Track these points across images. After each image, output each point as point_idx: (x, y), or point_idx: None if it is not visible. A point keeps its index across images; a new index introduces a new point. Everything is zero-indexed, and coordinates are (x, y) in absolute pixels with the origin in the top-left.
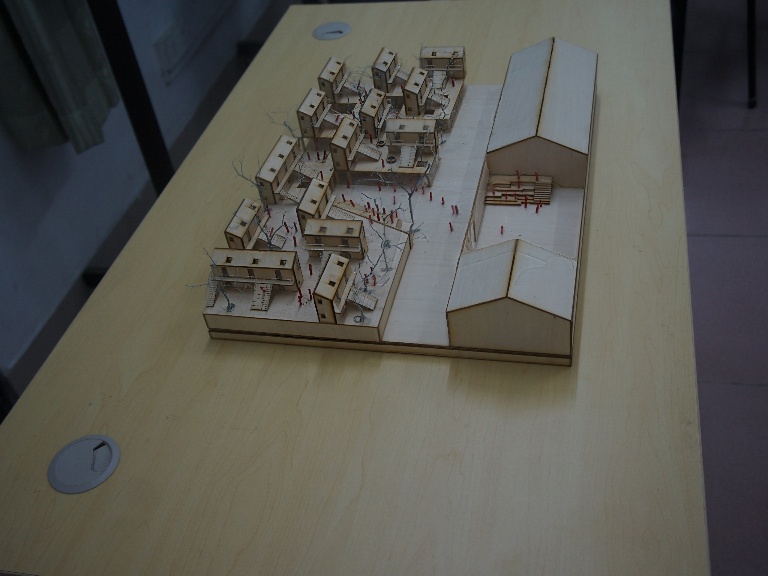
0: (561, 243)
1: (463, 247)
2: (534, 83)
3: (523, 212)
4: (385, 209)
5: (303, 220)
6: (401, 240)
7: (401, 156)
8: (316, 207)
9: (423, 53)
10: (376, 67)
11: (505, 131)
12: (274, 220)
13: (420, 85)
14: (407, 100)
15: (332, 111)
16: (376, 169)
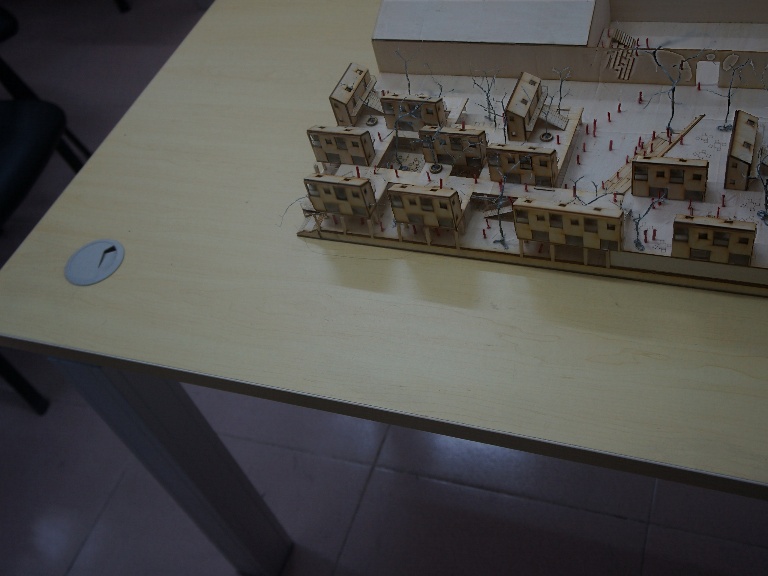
0: (704, 33)
1: (767, 52)
2: (477, 4)
3: (646, 57)
4: (621, 157)
5: (706, 178)
6: (718, 118)
7: (552, 122)
8: (692, 159)
9: (341, 98)
10: (361, 134)
11: (558, 28)
12: (662, 234)
13: (422, 96)
14: (439, 114)
15: (377, 219)
16: (563, 149)
